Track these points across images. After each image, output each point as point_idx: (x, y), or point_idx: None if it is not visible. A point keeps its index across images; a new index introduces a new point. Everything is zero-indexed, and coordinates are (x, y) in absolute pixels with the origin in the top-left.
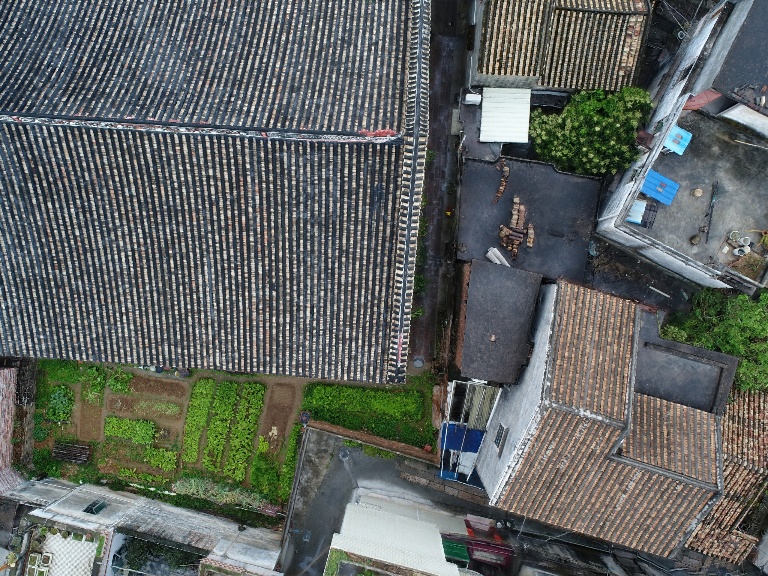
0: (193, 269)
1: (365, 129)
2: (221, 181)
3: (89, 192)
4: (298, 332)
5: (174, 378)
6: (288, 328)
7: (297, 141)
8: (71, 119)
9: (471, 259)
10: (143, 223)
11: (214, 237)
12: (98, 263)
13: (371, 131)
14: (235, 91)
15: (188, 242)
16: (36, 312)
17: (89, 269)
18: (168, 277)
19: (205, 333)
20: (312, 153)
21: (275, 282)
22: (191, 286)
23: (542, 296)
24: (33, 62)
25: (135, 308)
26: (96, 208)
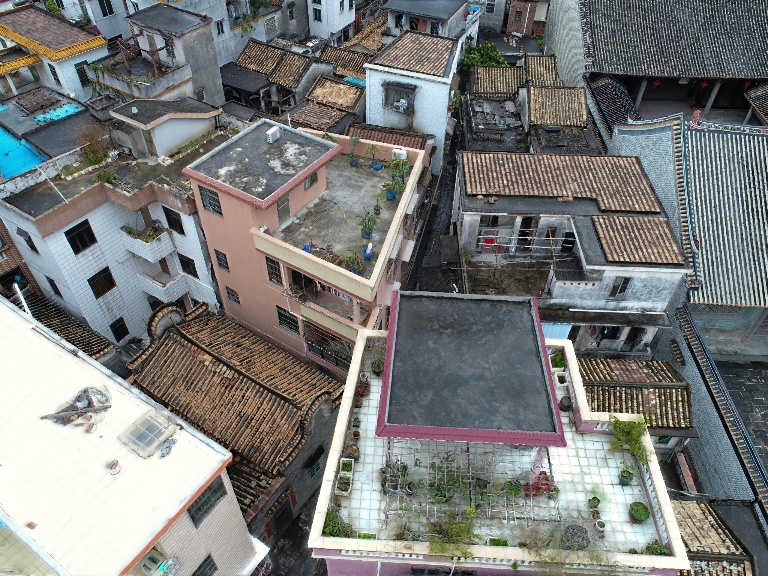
0: None
1: None
2: None
3: None
4: None
5: None
6: None
7: None
8: None
9: (528, 36)
10: None
11: None
12: None
13: None
14: (652, 5)
15: None
16: None
17: None
18: None
19: None
20: None
21: None
22: None
23: (507, 1)
24: None
25: None
26: None
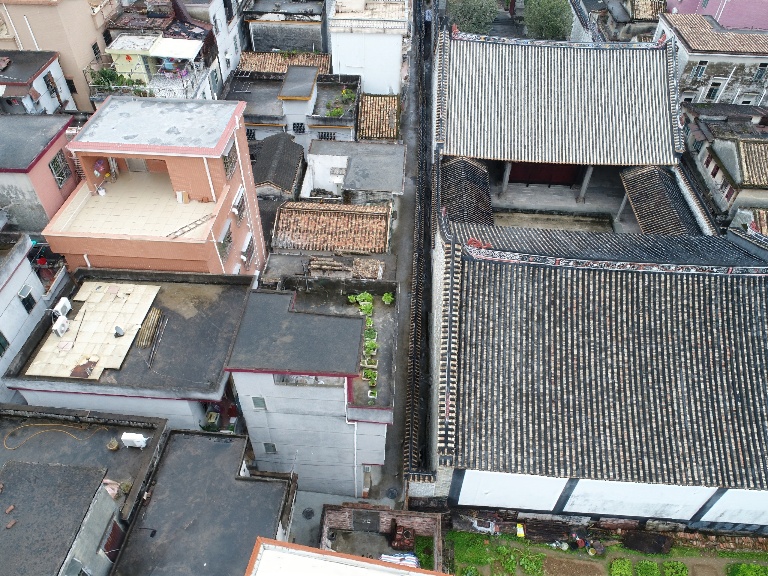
0: (668, 383)
1: None
2: (692, 308)
3: (590, 319)
4: (767, 441)
5: (586, 559)
6: (756, 438)
7: (750, 277)
8: (598, 260)
9: None
10: (629, 343)
11: (686, 354)
12: (588, 379)
13: None
14: None
15: (664, 359)
16: (529, 425)
17: (580, 384)
18: (647, 390)
19: (682, 445)
20: (761, 285)
21: (739, 393)
22: (667, 399)
23: None
24: None
25: (617, 421)
26: (594, 331)
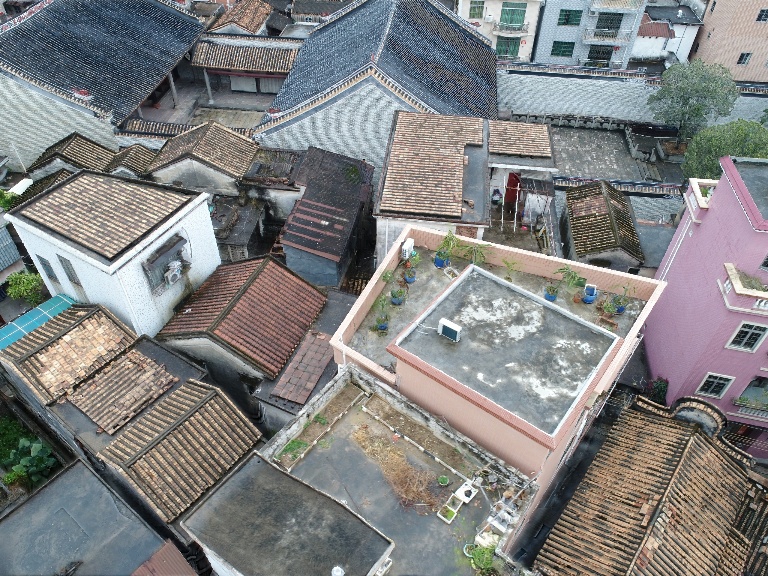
0: None
1: None
2: None
3: None
4: None
5: None
6: None
7: None
8: None
9: None
10: None
11: None
12: None
13: None
14: None
15: None
16: None
17: None
18: None
19: None
20: None
21: None
22: None
23: None
24: (111, 8)
25: None
26: None
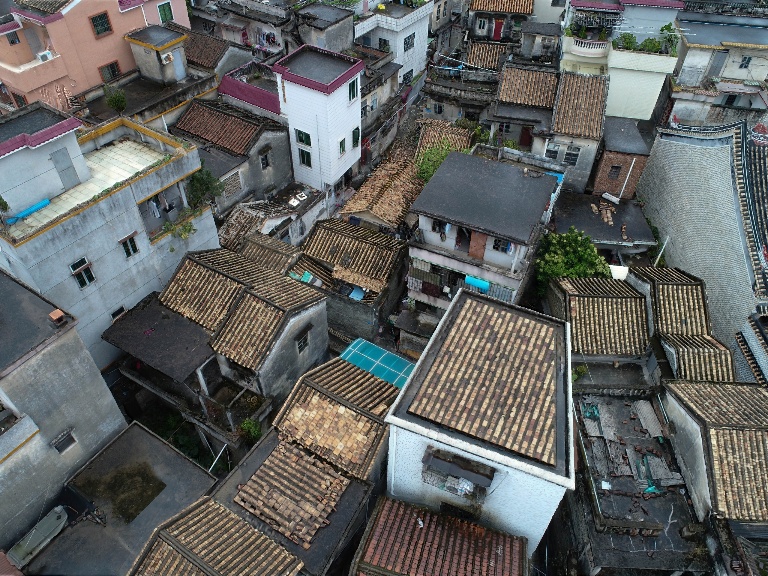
0: None
1: (765, 154)
2: None
3: None
4: None
5: None
6: None
7: None
8: None
9: (628, 200)
10: None
11: None
12: None
13: (762, 152)
14: None
15: None
16: None
17: None
18: None
19: None
20: None
21: None
22: None
23: None
24: None
25: None
26: None
